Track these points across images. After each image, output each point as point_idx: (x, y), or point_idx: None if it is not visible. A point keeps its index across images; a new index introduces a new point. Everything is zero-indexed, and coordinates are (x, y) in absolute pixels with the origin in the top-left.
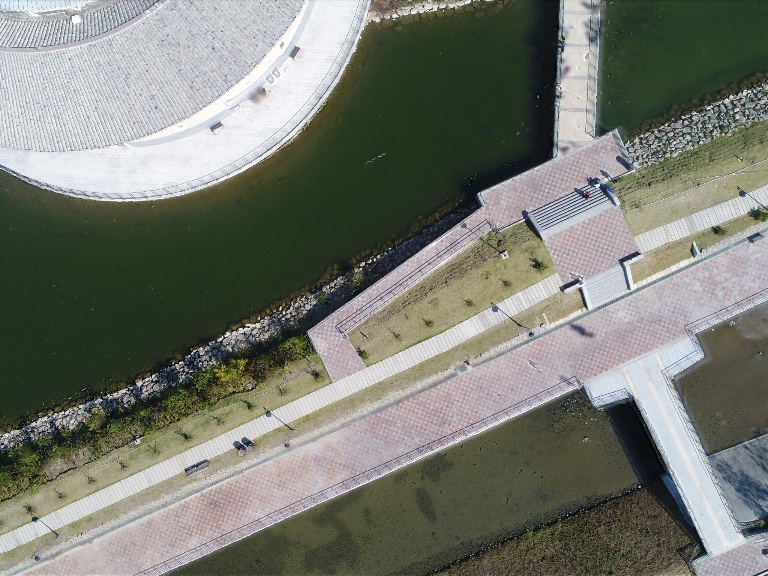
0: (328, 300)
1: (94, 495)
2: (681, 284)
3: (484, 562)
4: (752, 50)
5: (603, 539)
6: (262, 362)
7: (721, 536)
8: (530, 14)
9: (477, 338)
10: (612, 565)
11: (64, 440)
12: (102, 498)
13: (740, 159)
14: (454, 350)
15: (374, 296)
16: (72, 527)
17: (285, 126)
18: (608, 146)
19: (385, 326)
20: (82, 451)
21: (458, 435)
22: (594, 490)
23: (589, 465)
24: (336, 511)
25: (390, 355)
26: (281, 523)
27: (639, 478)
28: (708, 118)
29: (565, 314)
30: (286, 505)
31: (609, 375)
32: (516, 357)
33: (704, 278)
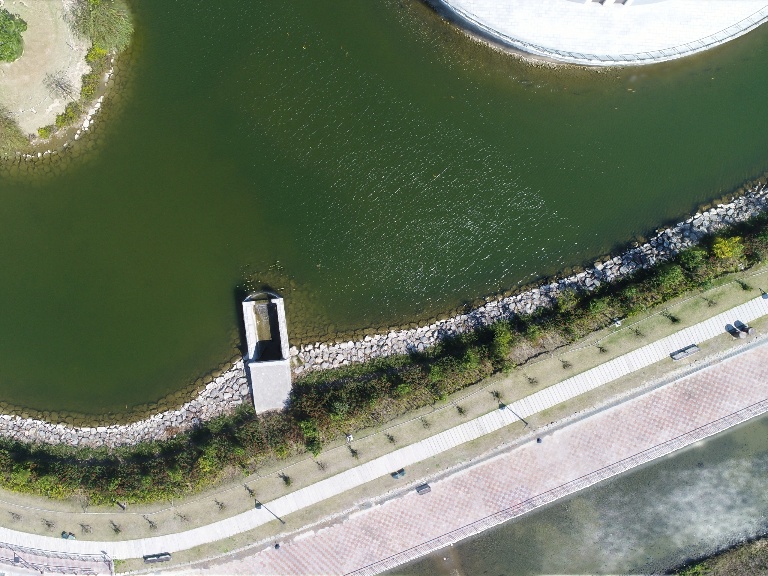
0: None
1: (569, 381)
2: None
3: None
4: None
5: None
6: (759, 240)
7: None
8: None
9: None
10: None
11: (524, 324)
12: (577, 384)
13: None
14: None
15: None
16: (543, 415)
17: None
18: None
19: None
20: (550, 335)
21: None
22: None
23: None
24: None
25: None
26: None
27: None
28: None
29: None
30: (767, 397)
31: None
32: None
33: None
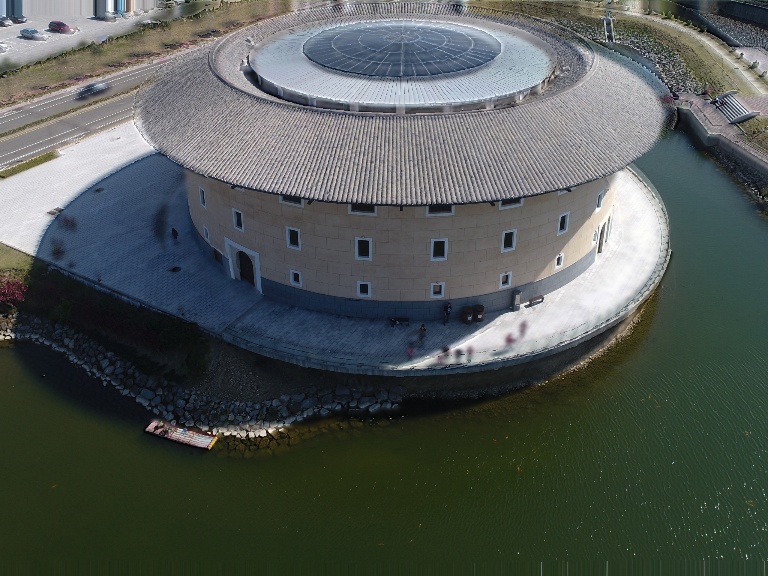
0: None
1: None
2: None
3: None
4: None
5: None
6: None
7: None
8: None
9: None
10: None
11: None
12: None
13: None
14: None
15: None
16: None
17: None
18: None
19: None
20: None
21: None
22: None
23: None
24: None
25: None
26: None
27: None
28: None
29: None
30: None
31: None
32: None
33: None
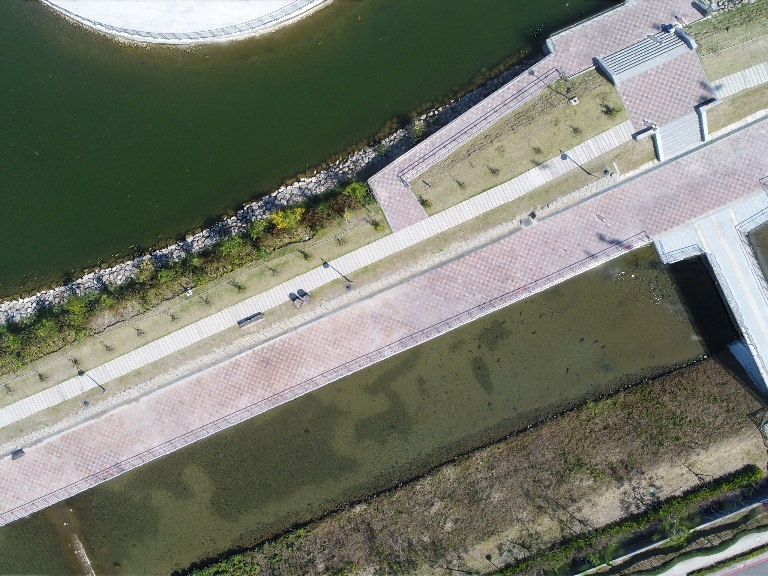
0: (388, 152)
1: (143, 348)
2: (757, 136)
3: (543, 432)
4: None
5: (668, 407)
6: (320, 211)
7: None
8: None
9: (544, 187)
10: (679, 431)
11: (111, 295)
12: (151, 351)
13: None
14: (520, 199)
15: (437, 144)
16: (119, 381)
17: None
18: None
19: (449, 174)
20: (131, 304)
21: (521, 292)
22: (658, 360)
23: (653, 334)
24: (389, 380)
25: (453, 204)
26: (331, 392)
27: (705, 348)
28: None
29: (635, 166)
30: (341, 364)
31: (680, 230)
32: (583, 211)
33: None
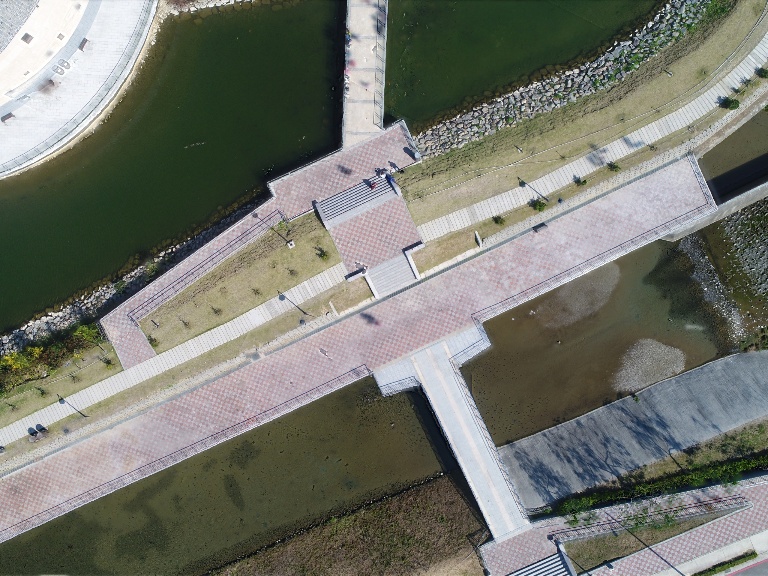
0: (127, 289)
1: None
2: (468, 273)
3: (288, 548)
4: (544, 43)
5: (401, 525)
6: (55, 350)
7: (507, 522)
8: (326, 7)
9: (264, 326)
10: (405, 551)
11: None
12: None
13: (520, 150)
14: (242, 338)
15: (166, 285)
16: None
17: (75, 117)
18: (396, 137)
19: (175, 314)
20: None
21: (251, 422)
22: (398, 477)
23: (393, 453)
24: (146, 498)
25: (180, 343)
26: (93, 510)
27: (442, 465)
28: (497, 110)
29: (354, 303)
30: (85, 491)
31: (398, 363)
32: (307, 345)
33: (490, 267)
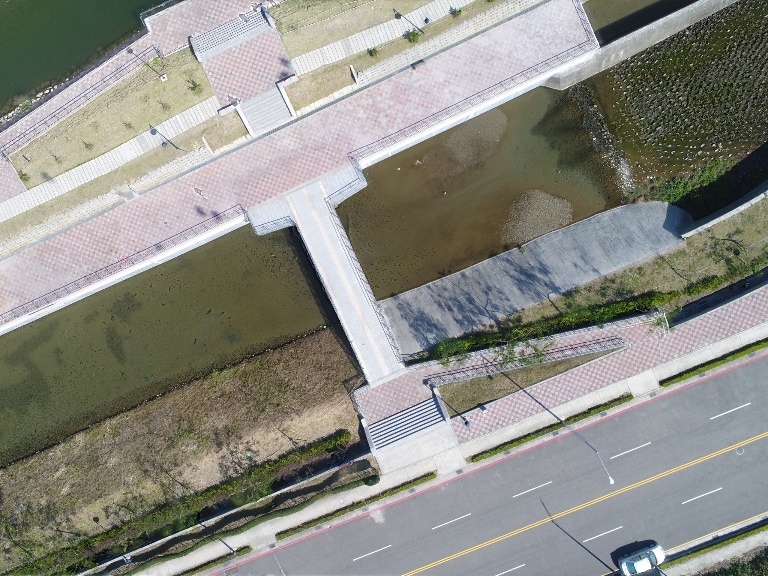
0: (2, 129)
1: None
2: (345, 111)
3: (168, 400)
4: None
5: (279, 375)
6: None
7: (382, 366)
8: None
9: (136, 161)
10: (281, 398)
11: None
12: None
13: None
14: (113, 173)
15: (38, 120)
16: None
17: None
18: None
19: (46, 149)
20: None
21: (125, 263)
22: (281, 331)
23: (276, 305)
24: (27, 351)
25: (50, 178)
26: None
27: (325, 319)
28: None
29: (229, 140)
30: None
31: (273, 203)
32: (182, 184)
33: (368, 105)
